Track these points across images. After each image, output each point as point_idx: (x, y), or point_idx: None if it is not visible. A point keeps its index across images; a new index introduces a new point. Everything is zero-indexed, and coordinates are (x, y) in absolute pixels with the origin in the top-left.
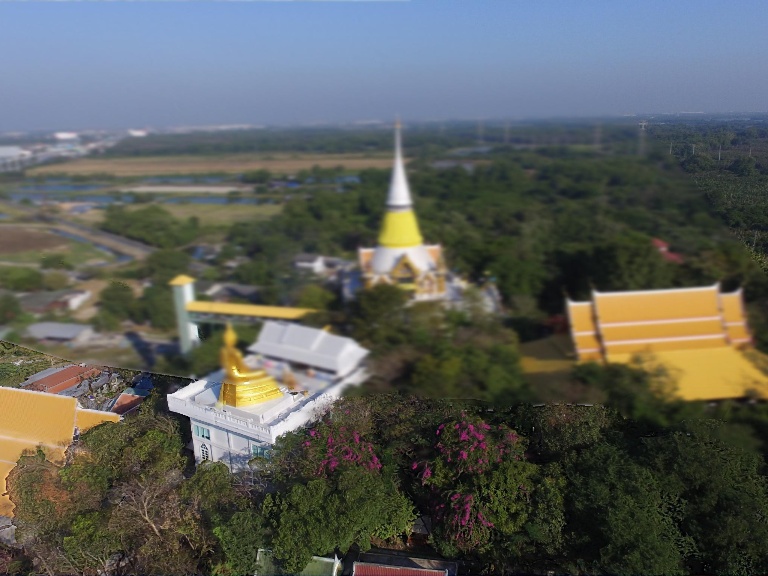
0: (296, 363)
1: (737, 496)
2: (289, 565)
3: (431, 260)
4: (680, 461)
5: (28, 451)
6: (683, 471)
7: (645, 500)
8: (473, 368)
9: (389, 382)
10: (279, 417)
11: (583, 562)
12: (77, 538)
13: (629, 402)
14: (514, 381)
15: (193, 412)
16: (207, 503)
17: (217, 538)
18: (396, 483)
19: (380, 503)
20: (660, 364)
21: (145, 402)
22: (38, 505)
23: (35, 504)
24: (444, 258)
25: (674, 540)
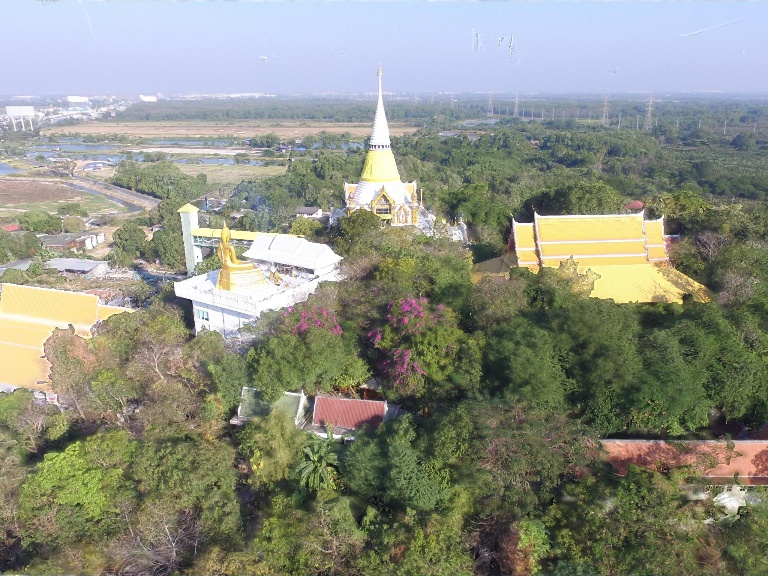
0: (215, 46)
1: (607, 345)
2: (265, 394)
3: (257, 6)
4: (569, 323)
5: None
6: (571, 330)
7: (540, 351)
8: (272, 45)
9: (245, 51)
10: None
11: (488, 392)
12: (102, 384)
13: (319, 53)
14: (285, 49)
15: (195, 295)
16: (204, 356)
17: (211, 377)
18: (356, 351)
19: (339, 357)
20: (327, 39)
21: None
22: (70, 363)
23: (68, 362)
24: (261, 5)
25: (560, 381)
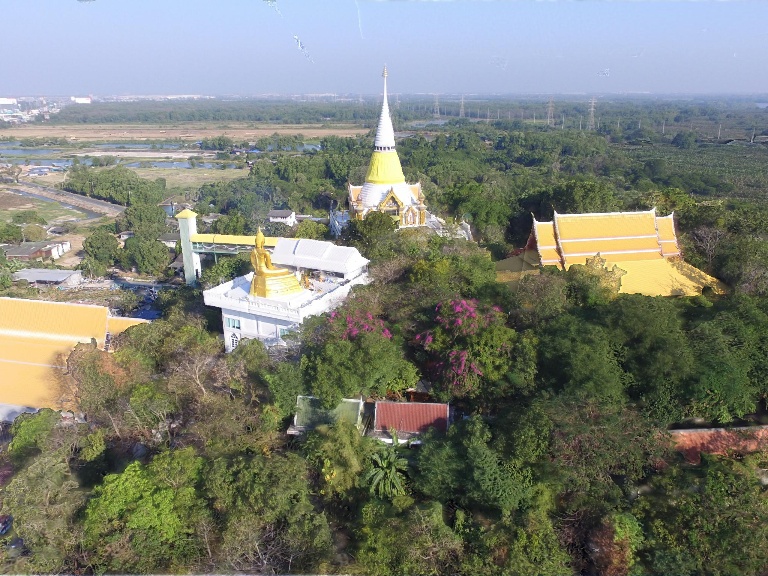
0: (498, 46)
1: (664, 339)
2: (326, 402)
3: (548, 5)
4: (624, 318)
5: (63, 355)
6: (626, 325)
7: (598, 347)
8: (560, 45)
9: (531, 51)
10: (302, 306)
11: (552, 390)
12: (140, 399)
13: (611, 54)
14: (573, 50)
15: (228, 303)
16: (251, 366)
17: None
18: (401, 355)
19: None
20: (621, 40)
21: (175, 306)
22: (99, 379)
23: (96, 378)
24: (553, 5)
25: (618, 375)
